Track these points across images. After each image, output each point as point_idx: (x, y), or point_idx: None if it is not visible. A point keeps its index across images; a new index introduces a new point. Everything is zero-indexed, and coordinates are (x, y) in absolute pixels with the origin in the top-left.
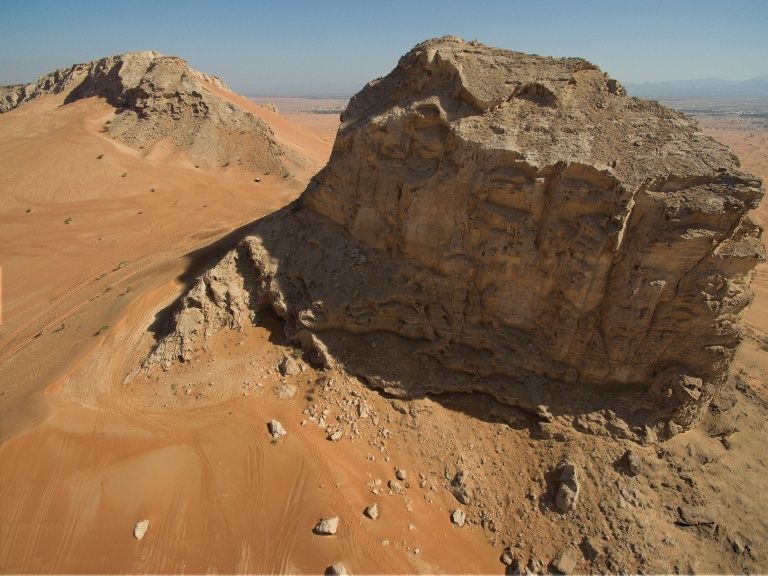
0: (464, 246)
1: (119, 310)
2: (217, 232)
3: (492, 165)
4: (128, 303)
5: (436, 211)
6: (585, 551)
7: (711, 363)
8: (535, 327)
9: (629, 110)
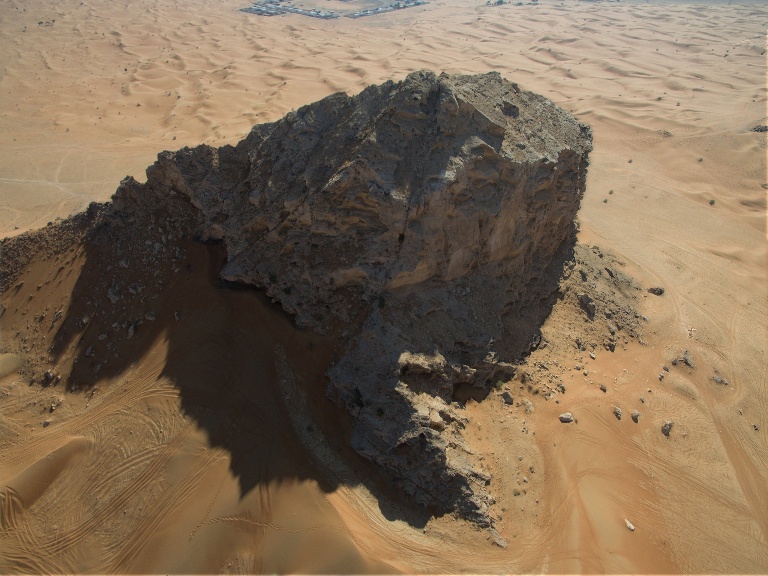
0: None
1: (360, 575)
2: (49, 470)
3: None
4: (358, 559)
5: None
6: (608, 317)
7: None
8: (538, 249)
9: None
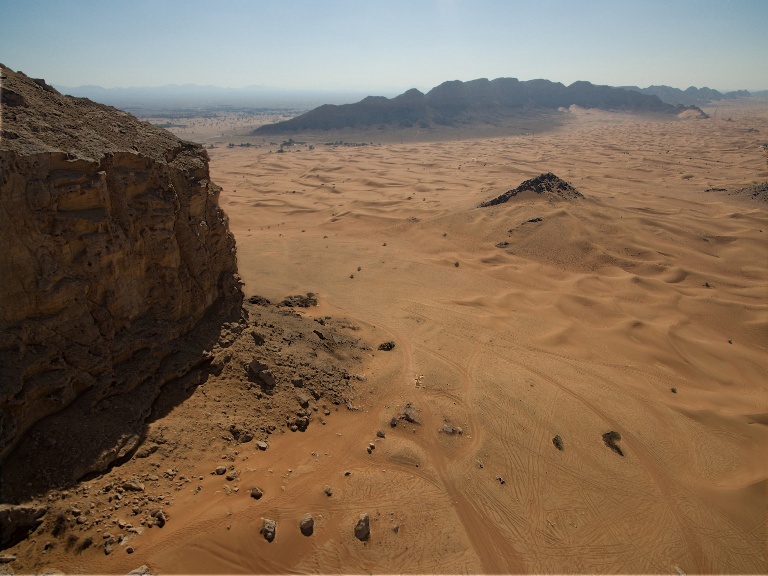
0: None
1: None
2: None
3: (46, 171)
4: None
5: None
6: (298, 386)
7: (234, 261)
8: (150, 307)
9: (79, 106)
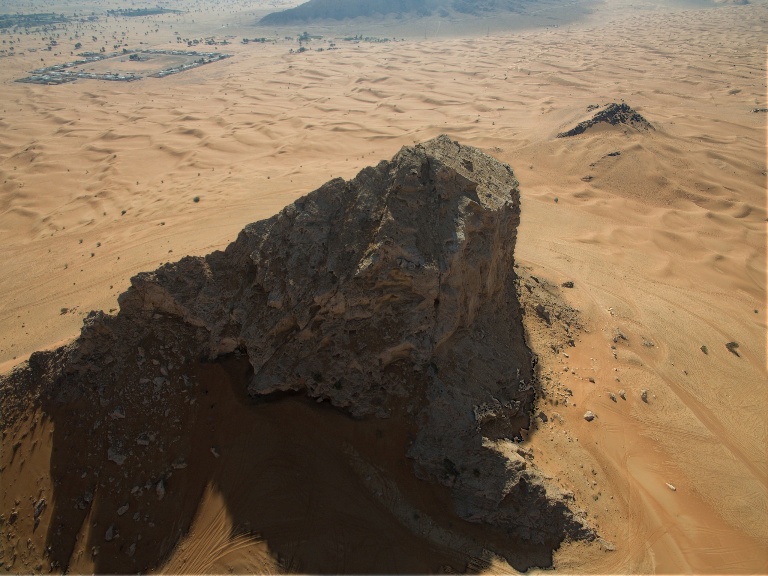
0: None
1: None
2: None
3: None
4: None
5: None
6: None
7: None
8: None
9: None
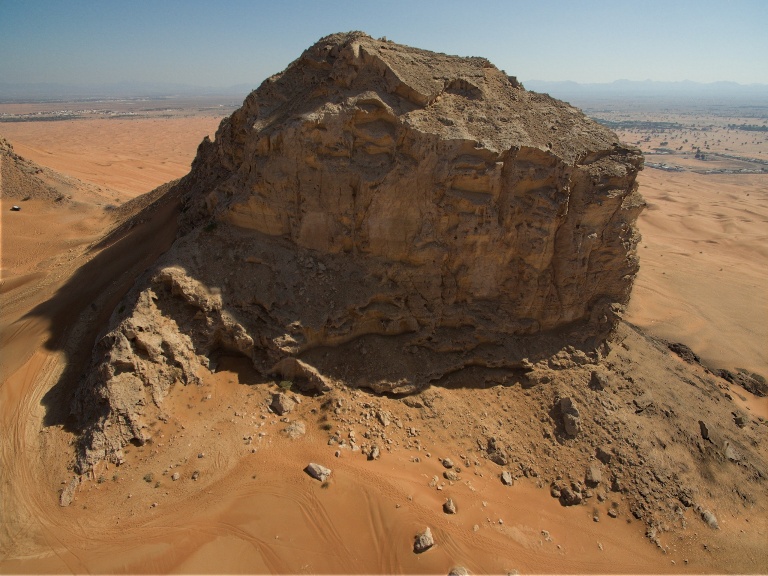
0: (434, 234)
1: None
2: (22, 281)
3: (454, 154)
4: None
5: (400, 205)
6: (602, 459)
7: (624, 289)
8: (500, 294)
9: (533, 101)
